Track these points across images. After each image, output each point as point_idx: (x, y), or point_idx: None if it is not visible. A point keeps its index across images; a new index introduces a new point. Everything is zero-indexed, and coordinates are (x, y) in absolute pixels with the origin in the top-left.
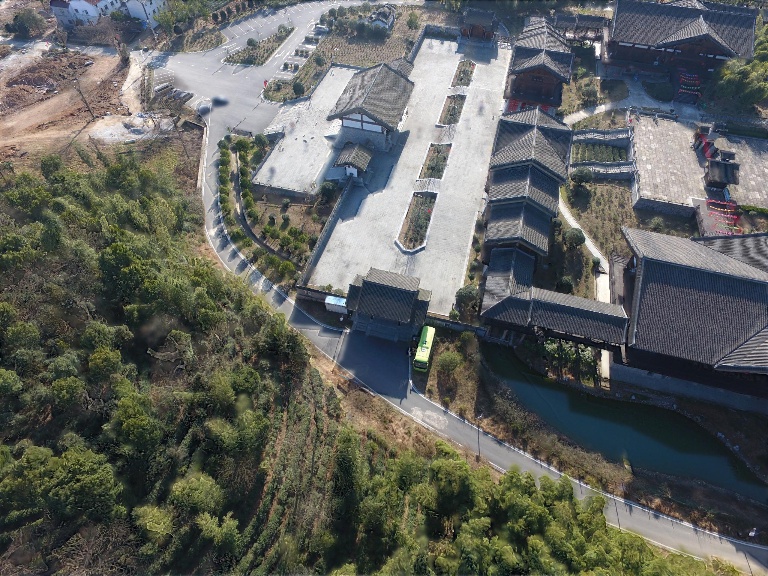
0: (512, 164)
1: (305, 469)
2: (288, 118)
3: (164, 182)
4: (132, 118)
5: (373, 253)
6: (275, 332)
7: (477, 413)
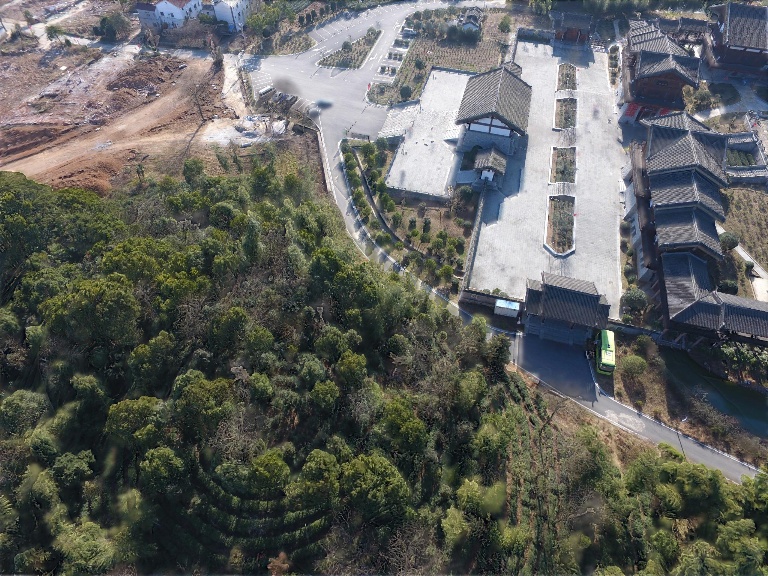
0: (674, 169)
1: (538, 471)
2: (402, 121)
3: (307, 186)
4: (241, 121)
5: (525, 257)
6: (482, 336)
7: (672, 416)
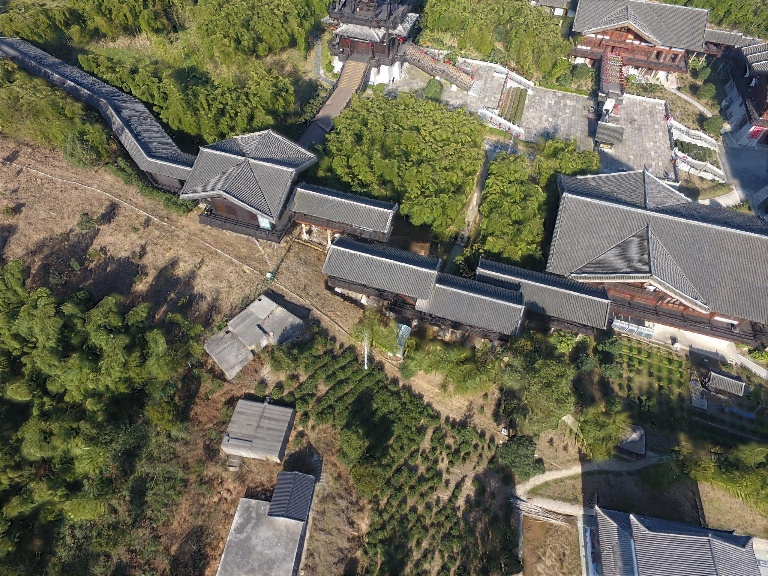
0: None
1: None
2: None
3: None
4: None
5: None
6: None
7: None
